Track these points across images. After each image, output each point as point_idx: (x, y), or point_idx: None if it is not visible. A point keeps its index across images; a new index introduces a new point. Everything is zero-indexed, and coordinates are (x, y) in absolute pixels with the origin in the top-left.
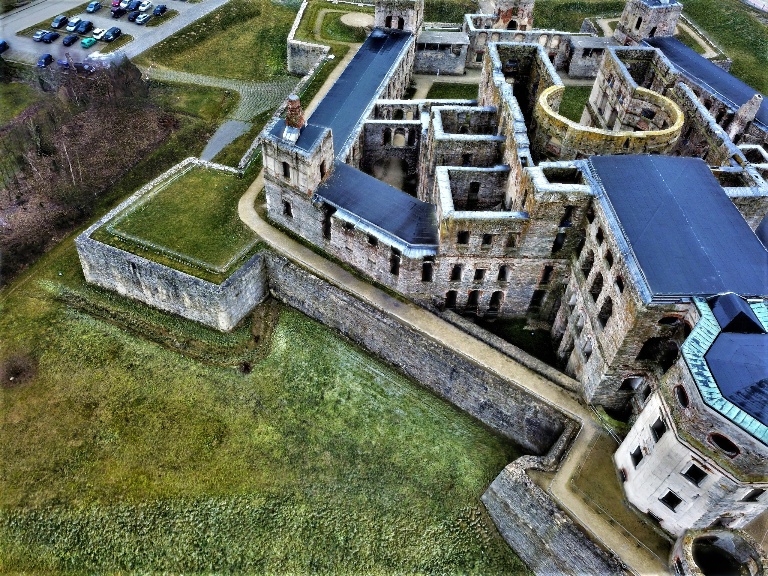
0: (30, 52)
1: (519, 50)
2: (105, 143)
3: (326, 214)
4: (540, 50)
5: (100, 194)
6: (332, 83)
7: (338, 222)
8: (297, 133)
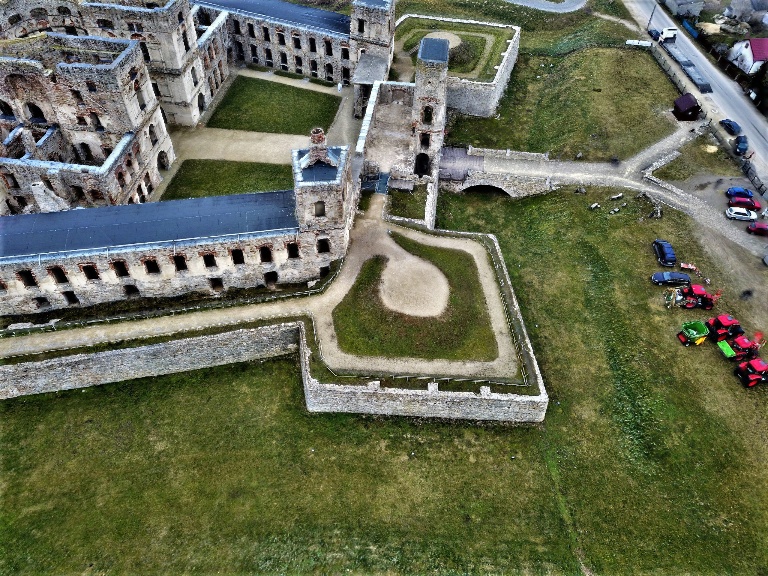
0: None
1: None
2: None
3: None
4: (154, 8)
5: None
6: None
7: None
8: None
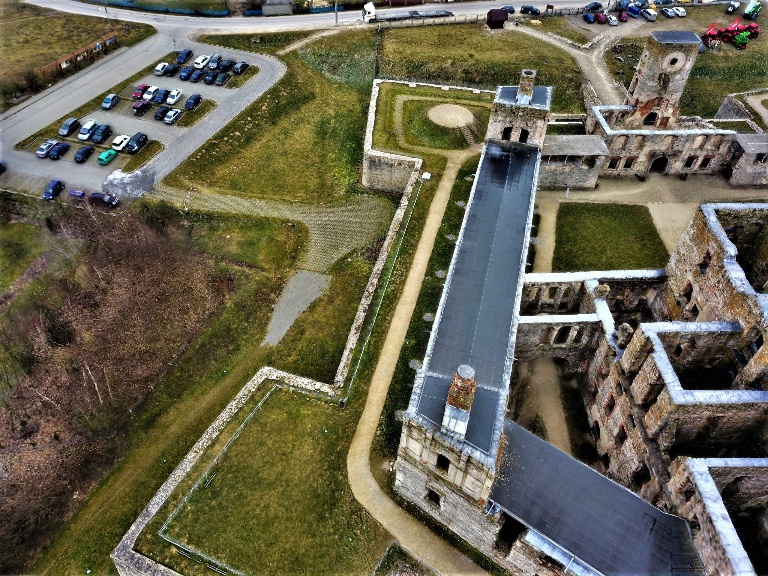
0: (33, 175)
1: (745, 215)
2: (138, 320)
3: (503, 523)
4: None
5: (136, 409)
6: (436, 221)
7: (531, 551)
8: (467, 420)
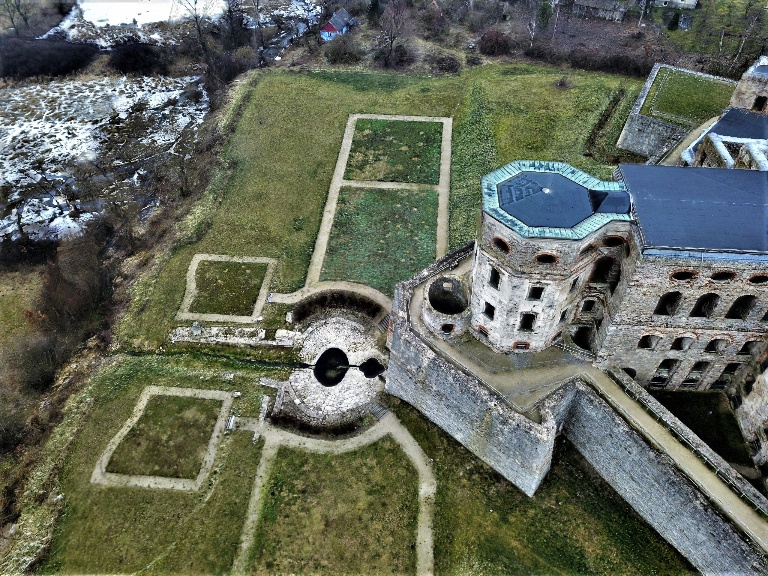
0: None
1: None
2: None
3: None
4: None
5: None
6: None
7: None
8: None
